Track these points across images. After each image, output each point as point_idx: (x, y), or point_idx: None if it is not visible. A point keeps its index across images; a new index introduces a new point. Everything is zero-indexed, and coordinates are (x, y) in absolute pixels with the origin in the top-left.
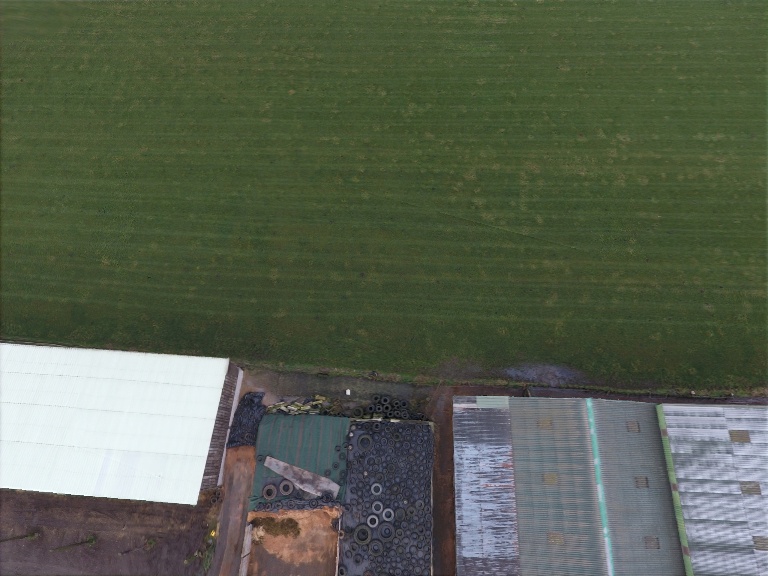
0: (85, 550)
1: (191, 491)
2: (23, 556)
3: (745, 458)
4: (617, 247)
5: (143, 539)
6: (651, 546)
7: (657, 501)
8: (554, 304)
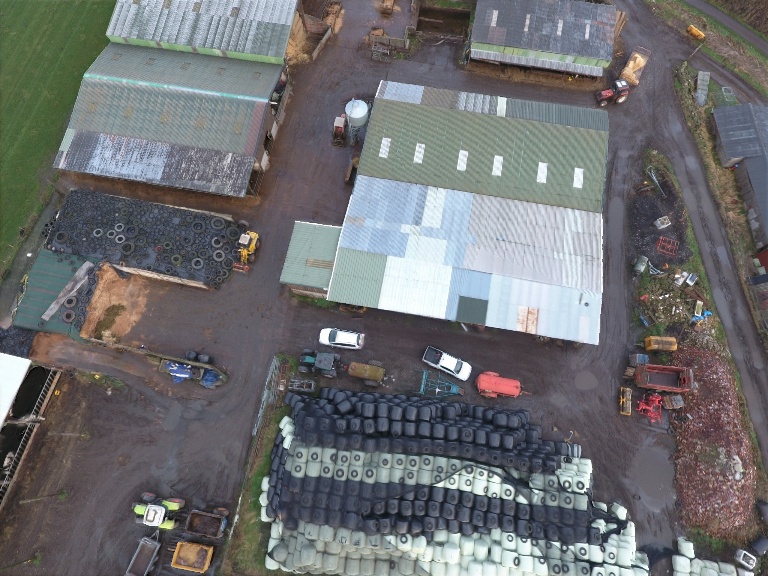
0: (69, 500)
1: (18, 365)
2: (53, 568)
3: (150, 0)
4: (6, 41)
5: (79, 442)
6: (187, 67)
7: (165, 57)
8: (30, 93)
